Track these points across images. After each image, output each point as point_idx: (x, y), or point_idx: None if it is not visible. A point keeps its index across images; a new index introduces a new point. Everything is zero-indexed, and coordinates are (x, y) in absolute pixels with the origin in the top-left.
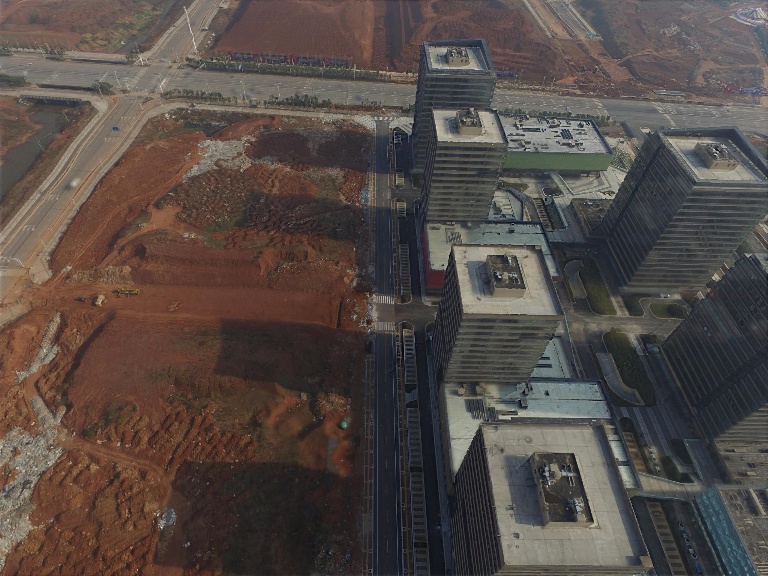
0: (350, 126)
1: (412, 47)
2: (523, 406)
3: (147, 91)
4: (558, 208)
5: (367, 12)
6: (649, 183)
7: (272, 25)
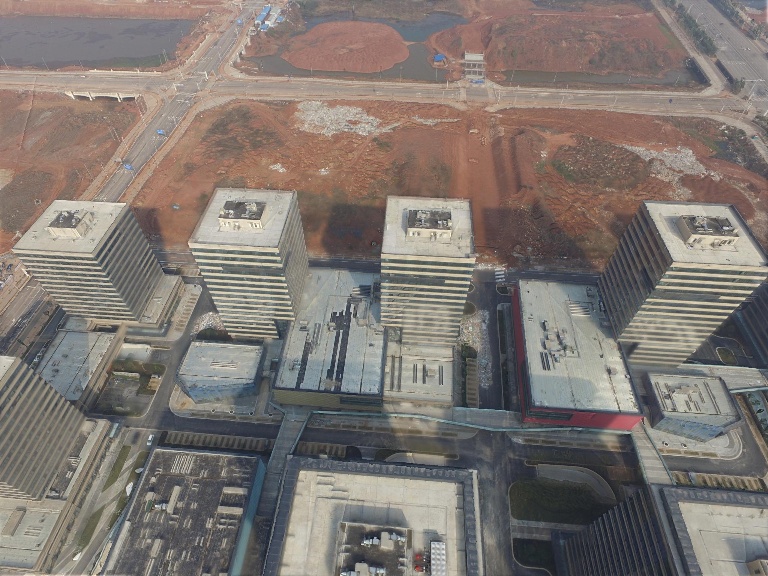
0: None
1: None
2: (359, 319)
3: (757, 108)
4: None
5: None
6: None
7: None
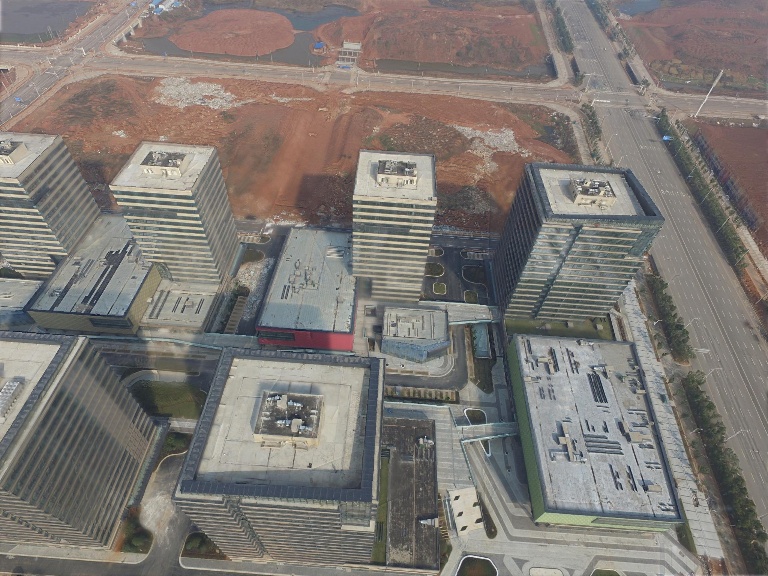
0: None
1: None
2: (129, 256)
3: (589, 99)
4: None
5: None
6: None
7: None
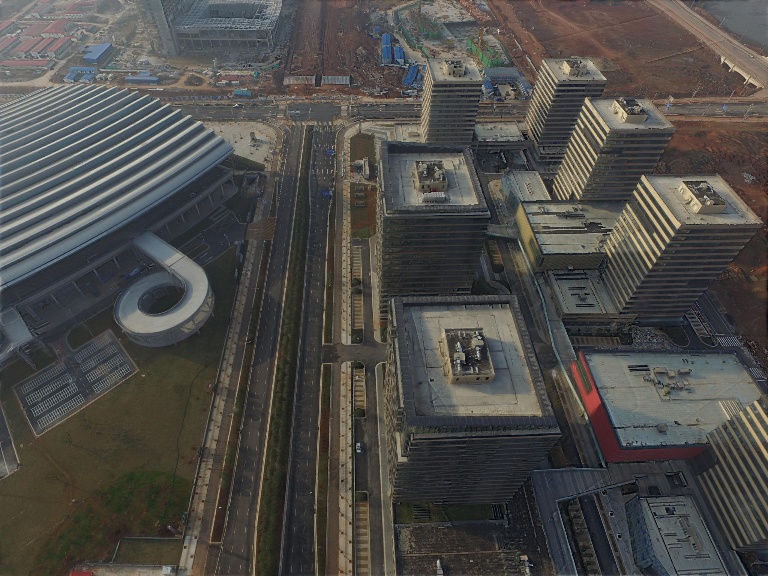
0: None
1: None
2: (602, 235)
3: None
4: None
5: None
6: None
7: None
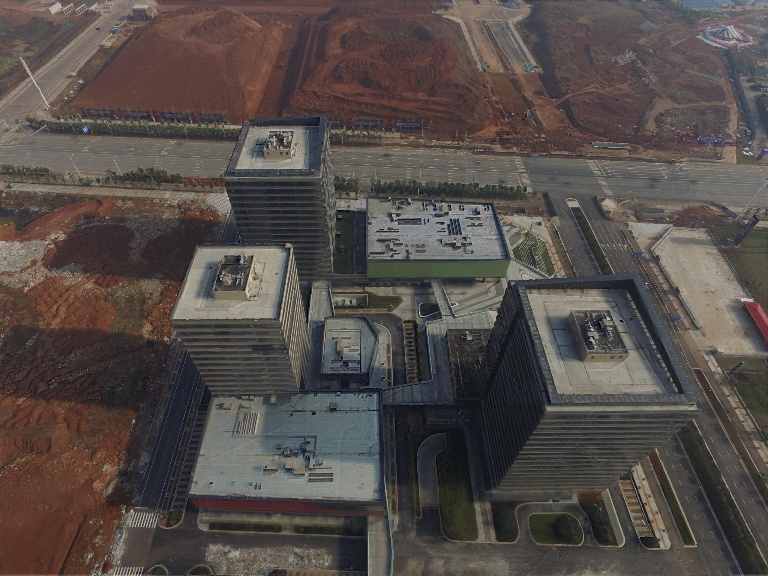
0: (197, 210)
1: (305, 94)
2: None
3: None
4: (428, 343)
5: (268, 47)
6: (509, 359)
7: (144, 70)
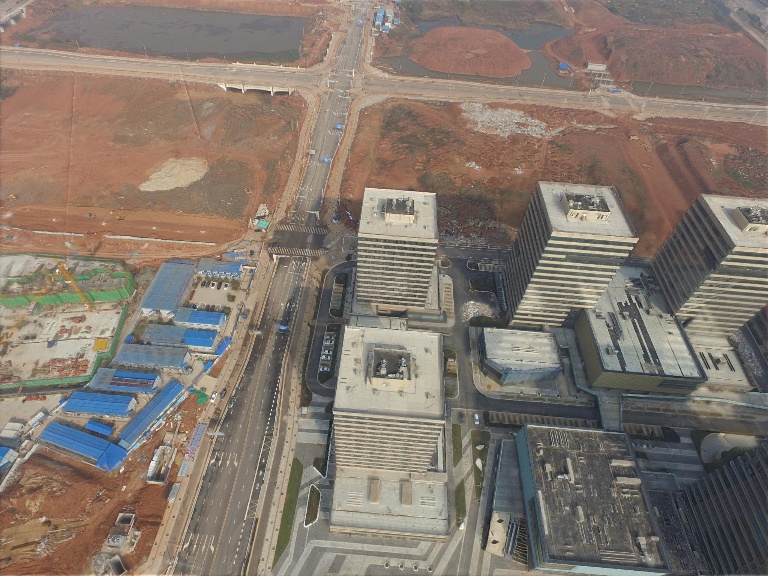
0: None
1: None
2: (649, 309)
3: None
4: None
5: None
6: None
7: None
